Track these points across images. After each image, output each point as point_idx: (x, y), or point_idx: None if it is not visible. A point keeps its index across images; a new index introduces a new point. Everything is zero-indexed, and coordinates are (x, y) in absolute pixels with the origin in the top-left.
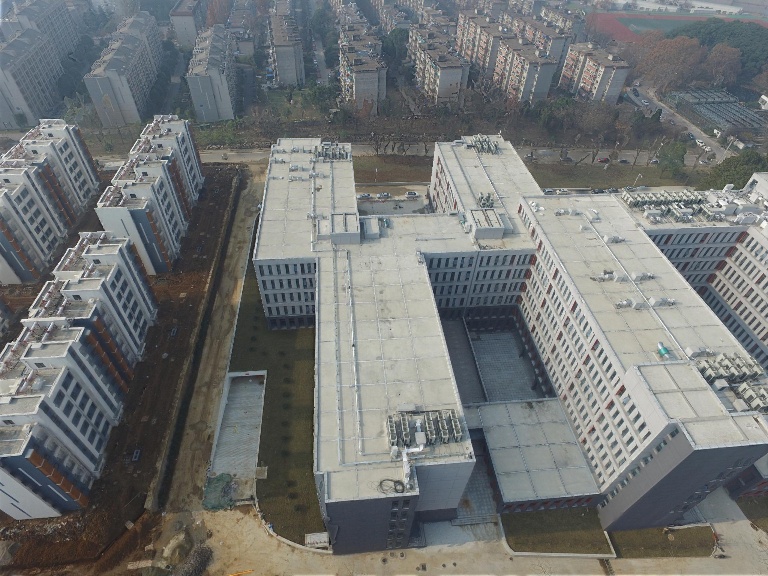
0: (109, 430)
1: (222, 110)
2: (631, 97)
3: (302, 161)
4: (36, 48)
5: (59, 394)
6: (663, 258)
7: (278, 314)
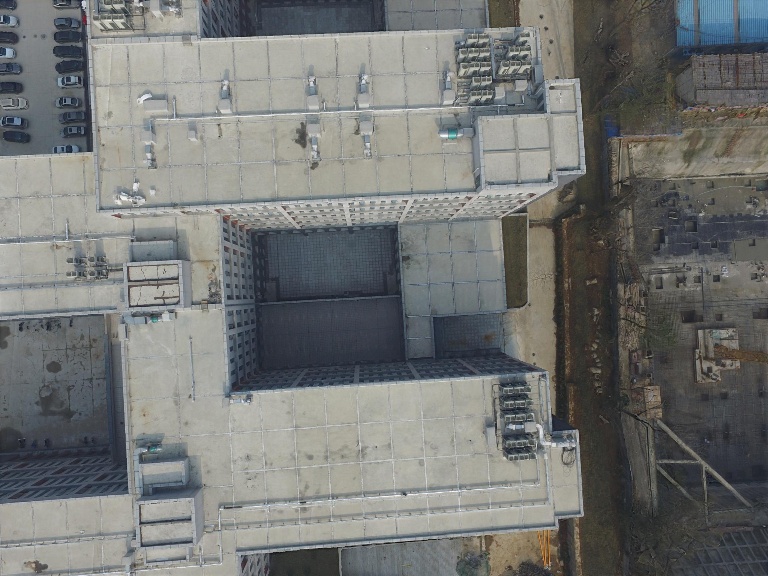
0: None
1: None
2: None
3: None
4: None
5: None
6: (270, 41)
7: (266, 556)
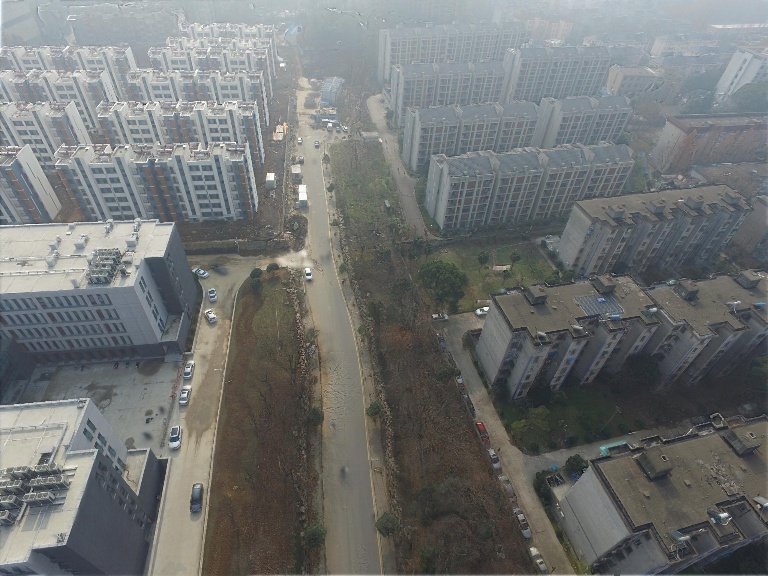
0: None
1: None
2: None
3: (104, 246)
4: (471, 76)
5: None
6: None
7: None
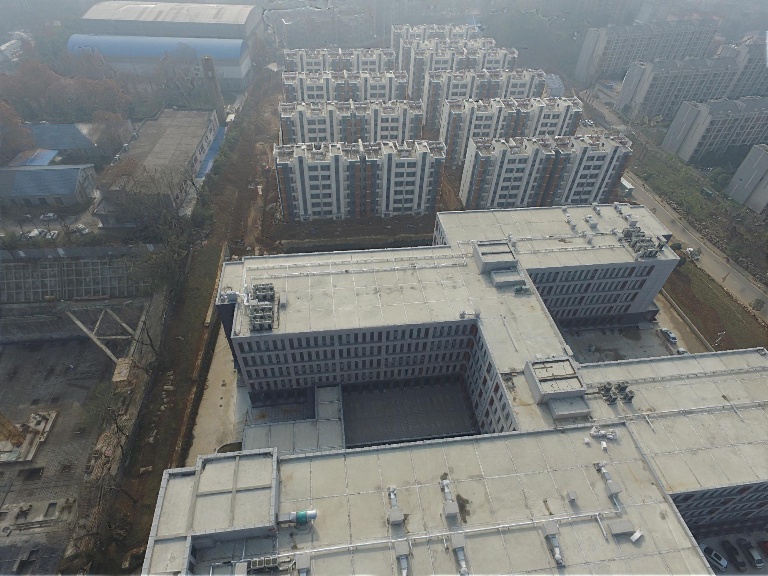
0: (330, 216)
1: (756, 197)
2: None
3: (611, 226)
4: (710, 71)
5: (316, 167)
6: None
7: None
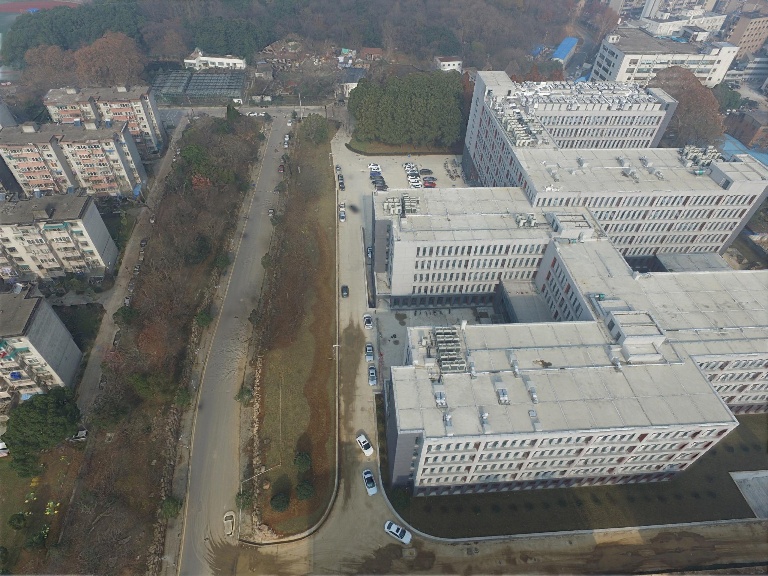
0: None
1: None
2: None
3: (472, 389)
4: None
5: None
6: (593, 150)
7: None
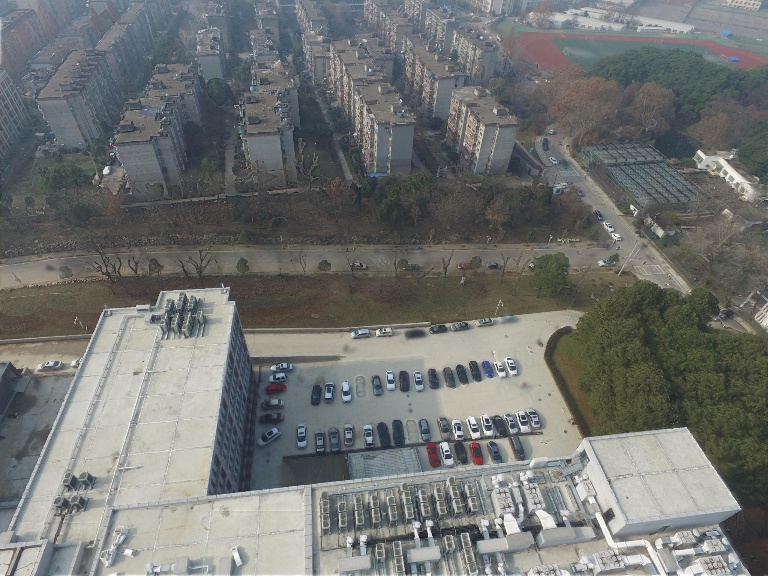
0: None
1: None
2: (538, 152)
3: None
4: None
5: None
6: None
7: None
